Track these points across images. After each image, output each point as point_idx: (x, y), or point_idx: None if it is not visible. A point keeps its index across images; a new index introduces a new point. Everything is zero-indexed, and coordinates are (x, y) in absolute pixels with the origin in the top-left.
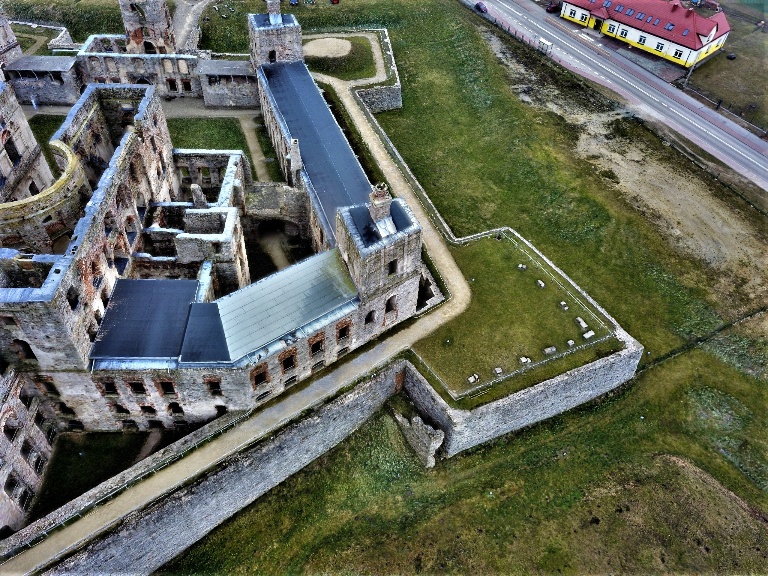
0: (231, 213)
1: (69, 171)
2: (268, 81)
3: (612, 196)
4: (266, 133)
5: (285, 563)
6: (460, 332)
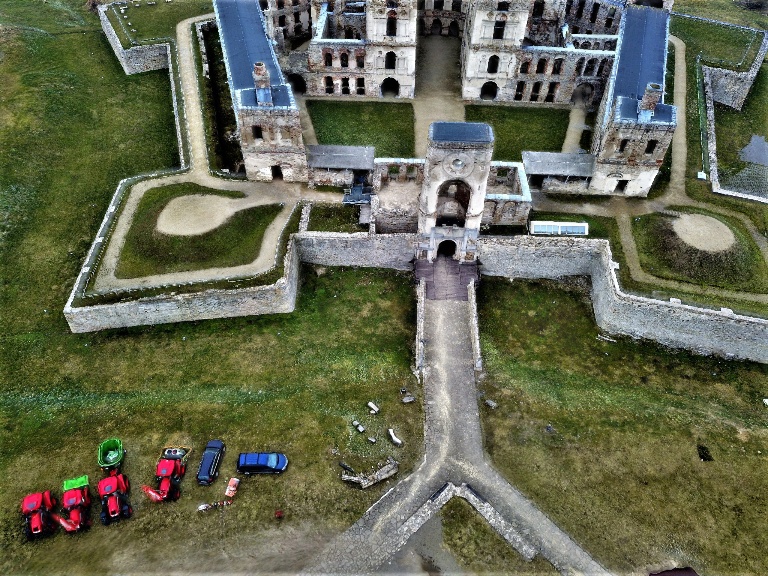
0: None
1: None
2: None
3: (3, 86)
4: None
5: None
6: (196, 11)
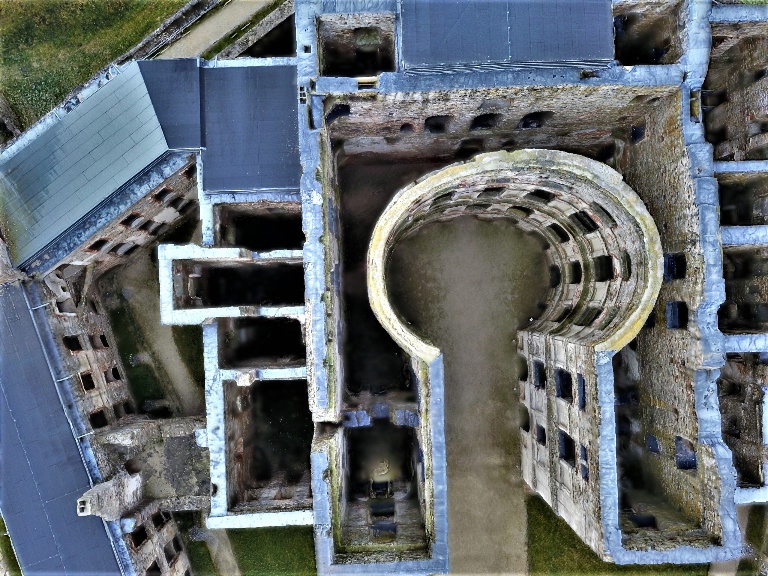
0: (167, 307)
1: (373, 269)
2: None
3: None
4: None
5: (149, 6)
6: None
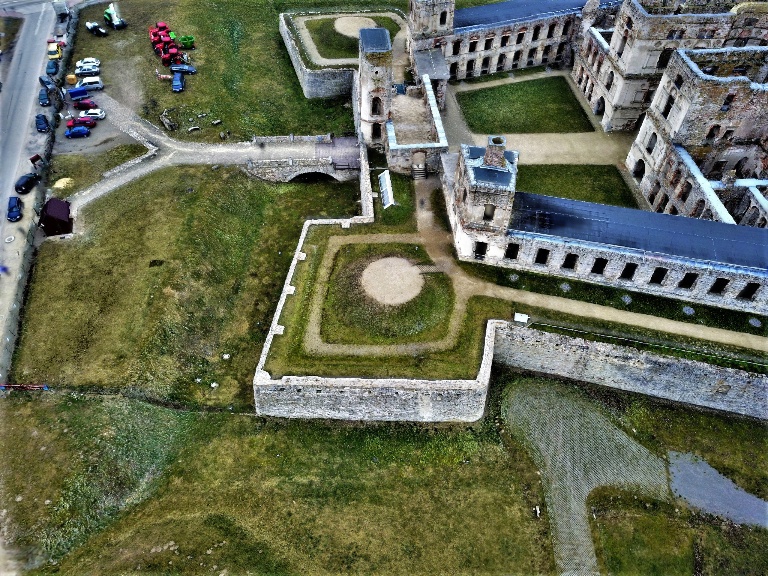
0: None
1: None
2: (481, 24)
3: None
4: (473, 78)
5: None
6: None
